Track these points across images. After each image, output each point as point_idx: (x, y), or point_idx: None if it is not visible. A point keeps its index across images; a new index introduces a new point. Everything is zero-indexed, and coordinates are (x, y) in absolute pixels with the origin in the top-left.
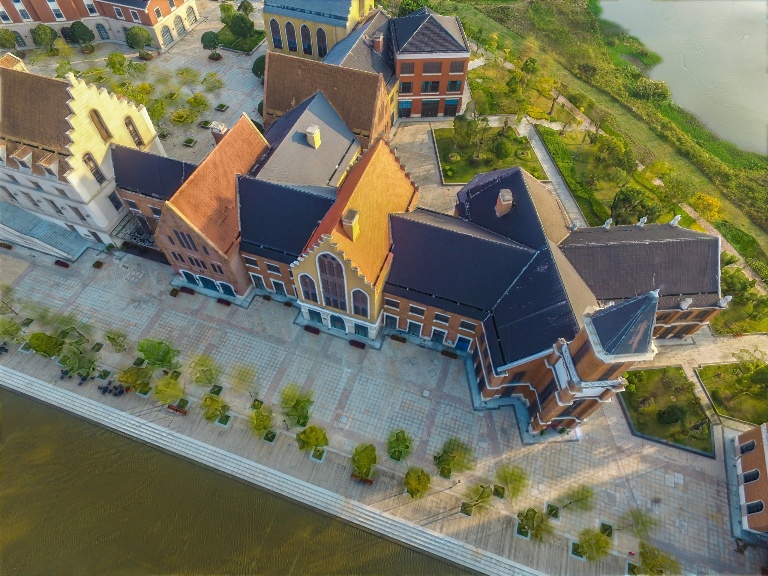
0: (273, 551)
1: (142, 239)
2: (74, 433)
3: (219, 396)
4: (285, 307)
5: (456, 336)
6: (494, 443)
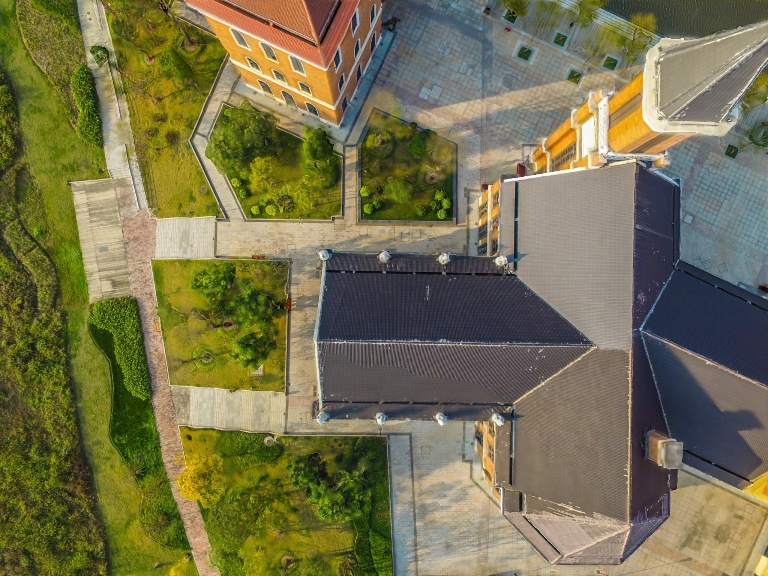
0: None
1: None
2: None
3: None
4: None
5: None
6: None
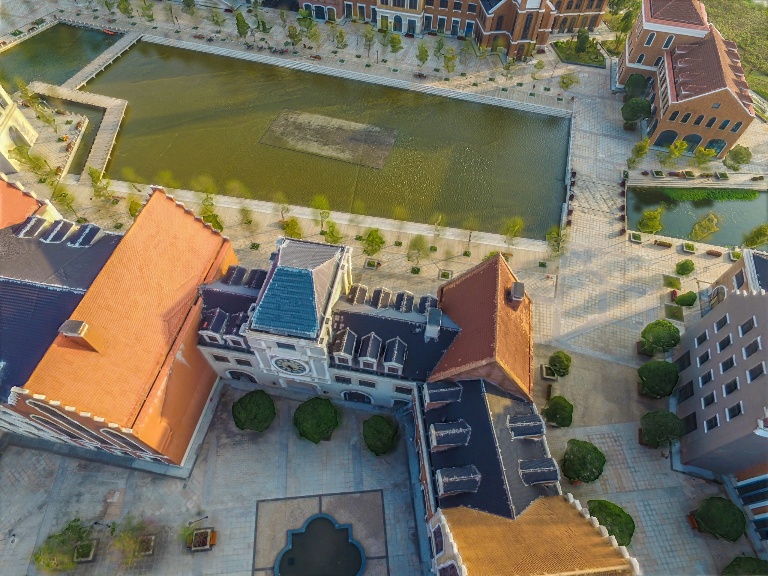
0: (378, 100)
1: (272, 1)
2: (261, 68)
3: (337, 54)
4: (365, 25)
5: (465, 22)
6: (488, 66)
